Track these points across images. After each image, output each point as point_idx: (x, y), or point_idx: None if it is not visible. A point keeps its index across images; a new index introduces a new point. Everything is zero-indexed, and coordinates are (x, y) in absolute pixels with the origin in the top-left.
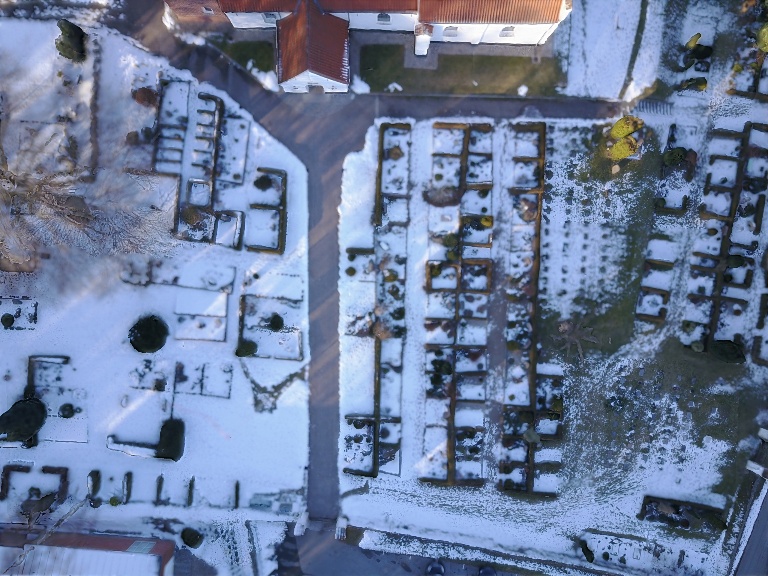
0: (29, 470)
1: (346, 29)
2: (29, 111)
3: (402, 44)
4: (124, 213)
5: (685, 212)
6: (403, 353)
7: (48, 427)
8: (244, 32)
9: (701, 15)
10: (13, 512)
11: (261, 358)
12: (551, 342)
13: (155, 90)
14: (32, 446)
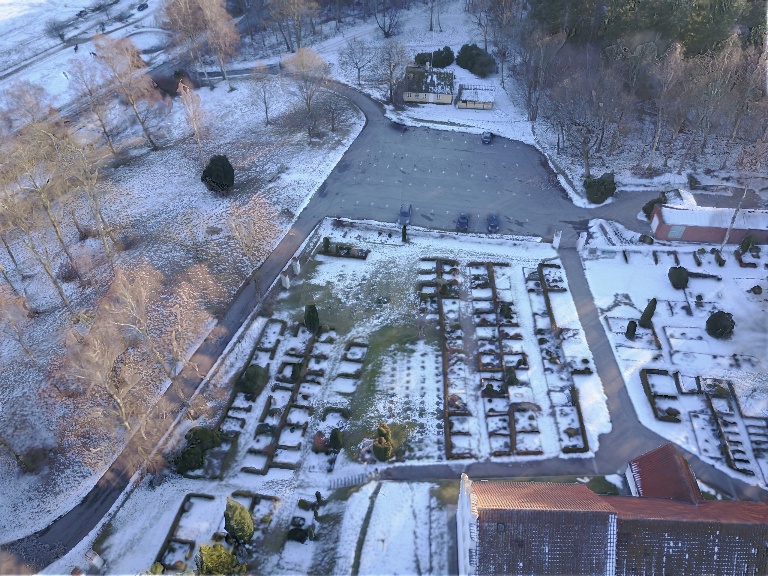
0: (765, 265)
1: None
2: None
3: None
4: None
5: None
6: (534, 323)
7: (765, 285)
8: None
9: (293, 572)
10: (764, 248)
11: None
12: (429, 330)
13: None
14: None
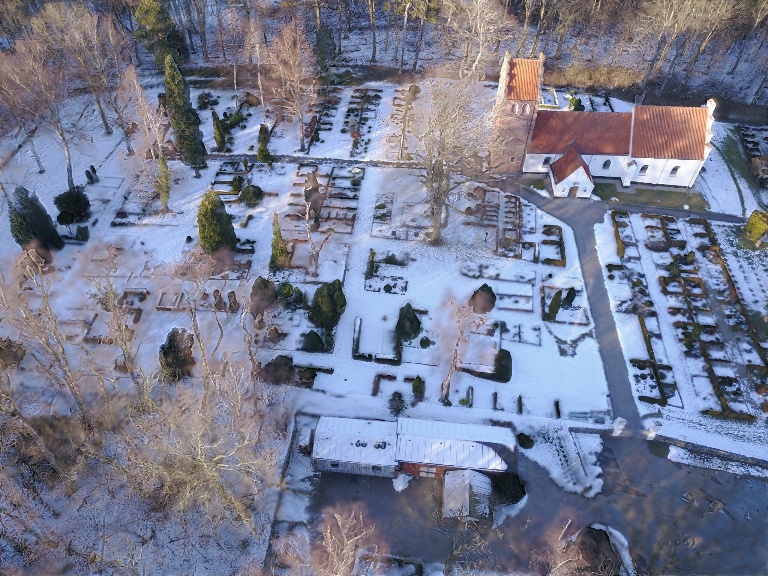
0: (395, 378)
1: (588, 168)
2: (409, 199)
3: (614, 183)
4: (464, 242)
5: None
6: (659, 328)
7: (409, 354)
8: (527, 175)
9: None
10: (380, 407)
11: (559, 323)
12: (762, 330)
13: None
14: (399, 362)
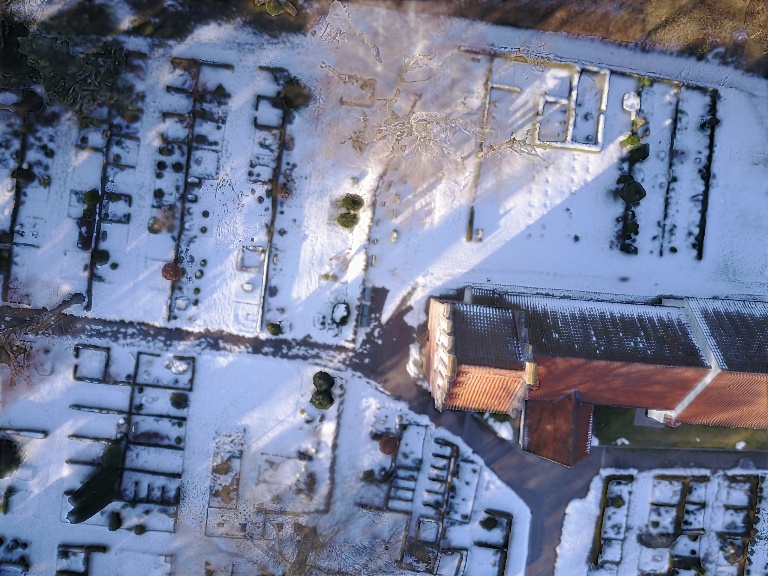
0: None
1: (592, 404)
2: (270, 444)
3: None
4: (352, 543)
5: None
6: None
7: None
8: None
9: None
10: None
11: None
12: None
13: (394, 433)
14: None
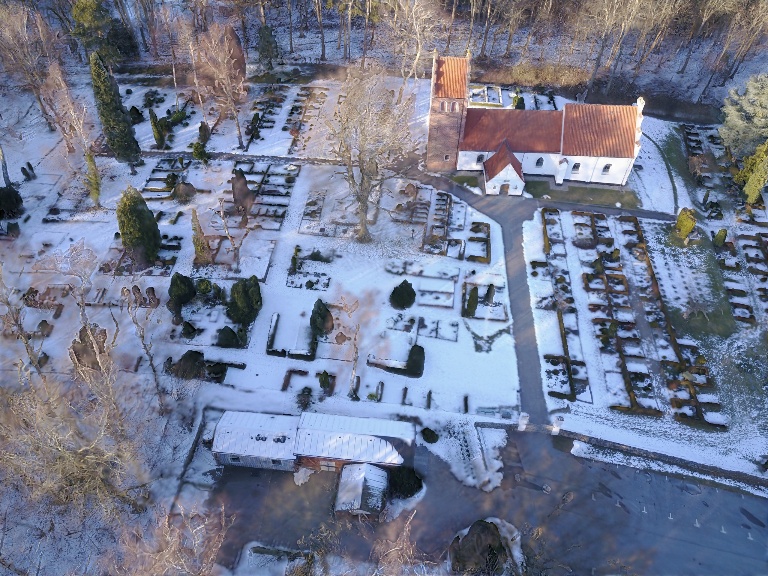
0: (307, 373)
1: None
2: (341, 196)
3: (547, 181)
4: (391, 239)
5: (740, 270)
6: (577, 324)
7: (324, 350)
8: (462, 173)
9: None
10: (288, 402)
11: (478, 319)
12: (680, 326)
13: None
14: (312, 357)
